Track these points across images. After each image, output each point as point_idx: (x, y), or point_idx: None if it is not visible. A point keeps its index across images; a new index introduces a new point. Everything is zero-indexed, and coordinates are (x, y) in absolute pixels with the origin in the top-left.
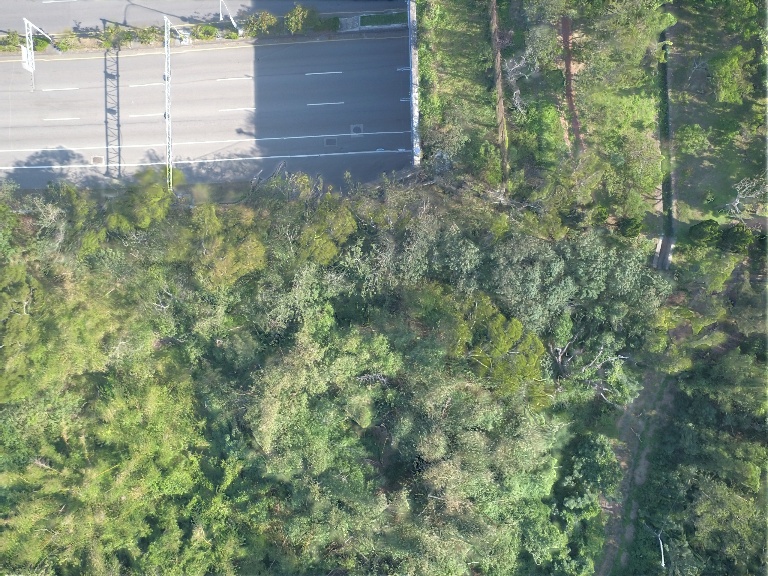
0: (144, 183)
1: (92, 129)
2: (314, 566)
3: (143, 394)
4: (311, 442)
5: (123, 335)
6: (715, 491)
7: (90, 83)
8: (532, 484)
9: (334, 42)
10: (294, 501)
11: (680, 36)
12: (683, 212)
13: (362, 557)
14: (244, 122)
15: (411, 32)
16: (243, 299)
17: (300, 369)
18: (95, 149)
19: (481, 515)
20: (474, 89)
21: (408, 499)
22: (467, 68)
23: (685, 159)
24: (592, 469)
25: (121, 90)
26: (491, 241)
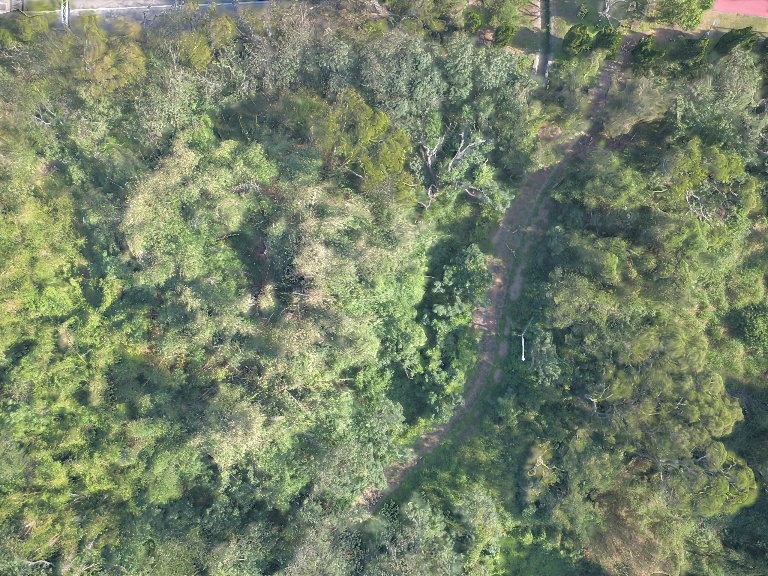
0: None
1: None
2: (187, 382)
3: (22, 211)
4: (183, 250)
5: (3, 151)
6: (574, 283)
7: None
8: (399, 285)
9: None
10: (169, 316)
11: None
12: (560, 28)
13: (234, 369)
14: None
15: None
16: (124, 115)
17: (175, 177)
18: None
19: (344, 310)
20: None
21: (271, 292)
22: None
23: None
24: (462, 276)
25: None
26: None
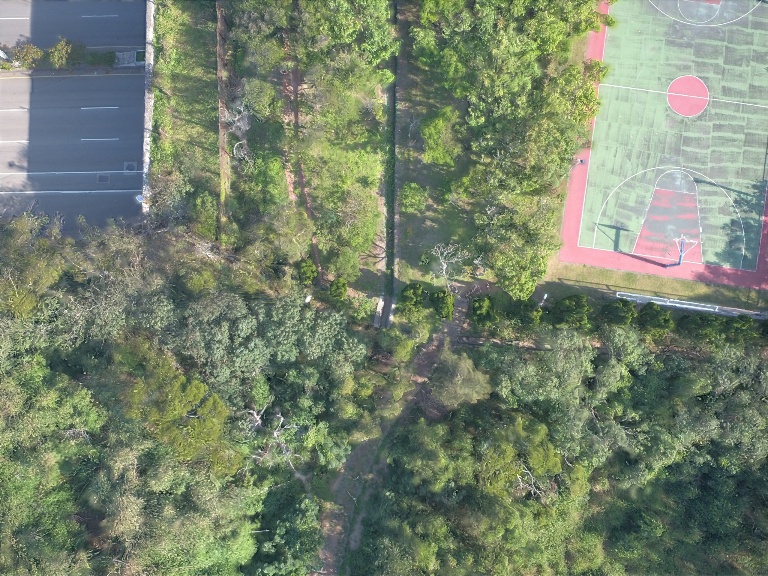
0: None
1: None
2: None
3: None
4: (13, 497)
5: None
6: (396, 566)
7: None
8: (224, 550)
9: (111, 76)
10: (4, 555)
11: (408, 91)
12: (404, 272)
13: None
14: (17, 155)
15: (146, 75)
16: None
17: (6, 420)
18: None
19: None
20: (208, 136)
21: (88, 563)
22: (201, 114)
23: (408, 217)
24: (294, 535)
25: None
26: None
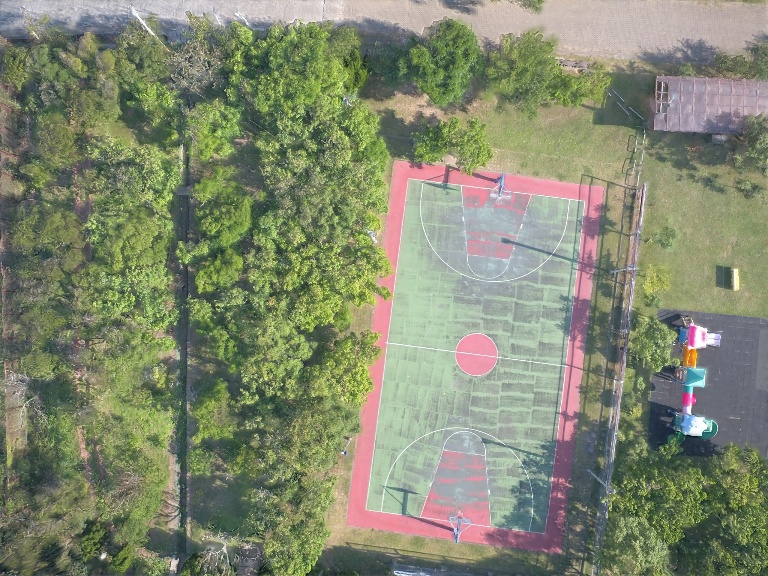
0: None
1: None
2: None
3: None
4: None
5: None
6: None
7: None
8: None
9: None
10: None
11: (198, 347)
12: (196, 531)
13: None
14: None
15: None
16: None
17: None
18: None
19: None
20: None
21: None
22: None
23: (199, 476)
24: None
25: None
26: None
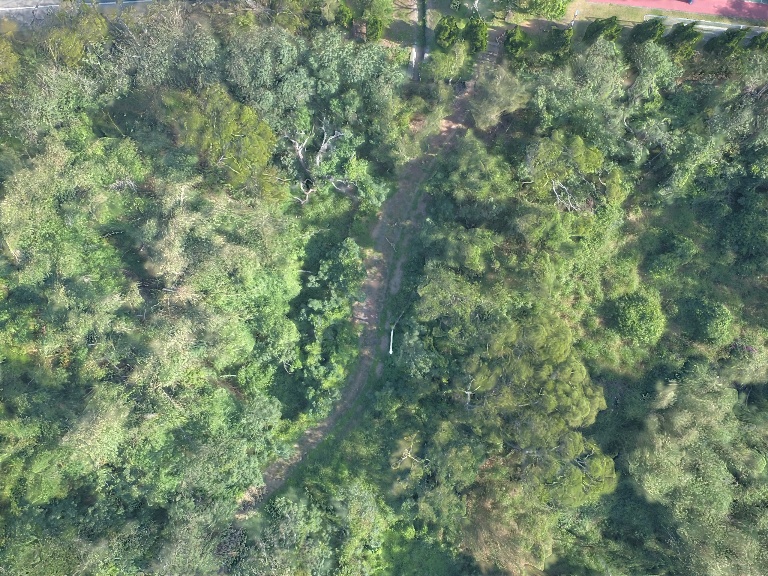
0: None
1: None
2: (70, 381)
3: None
4: (60, 248)
5: None
6: (440, 275)
7: None
8: (270, 280)
9: None
10: (51, 315)
11: None
12: (435, 20)
13: (113, 367)
14: None
15: None
16: (5, 114)
17: (51, 175)
18: None
19: (213, 306)
20: None
21: (138, 289)
22: None
23: None
24: (337, 271)
25: None
26: None
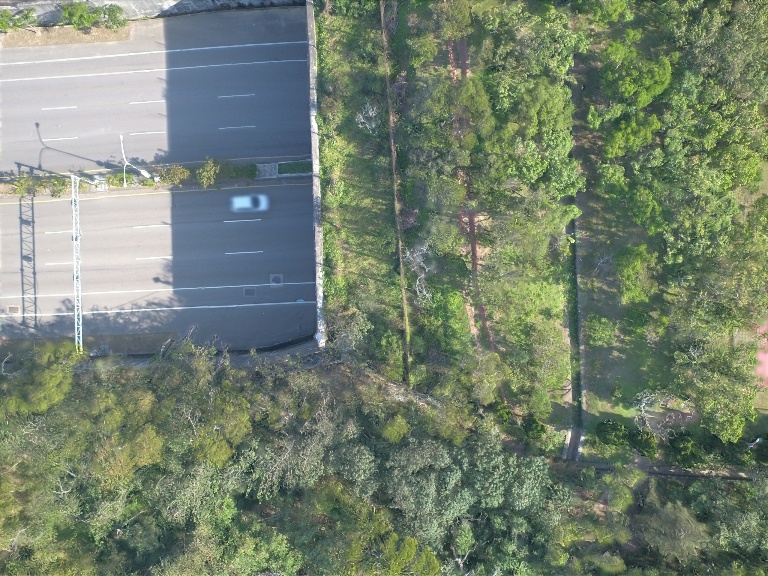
0: (61, 333)
1: (7, 277)
2: None
3: None
4: None
5: (24, 520)
6: None
7: (5, 230)
8: None
9: (252, 188)
10: None
11: (589, 220)
12: (592, 404)
13: None
14: (161, 271)
15: (315, 209)
16: (145, 485)
17: (199, 566)
18: (11, 298)
19: None
20: (380, 268)
21: None
22: (373, 246)
23: (594, 349)
24: None
25: (37, 237)
26: (393, 437)
